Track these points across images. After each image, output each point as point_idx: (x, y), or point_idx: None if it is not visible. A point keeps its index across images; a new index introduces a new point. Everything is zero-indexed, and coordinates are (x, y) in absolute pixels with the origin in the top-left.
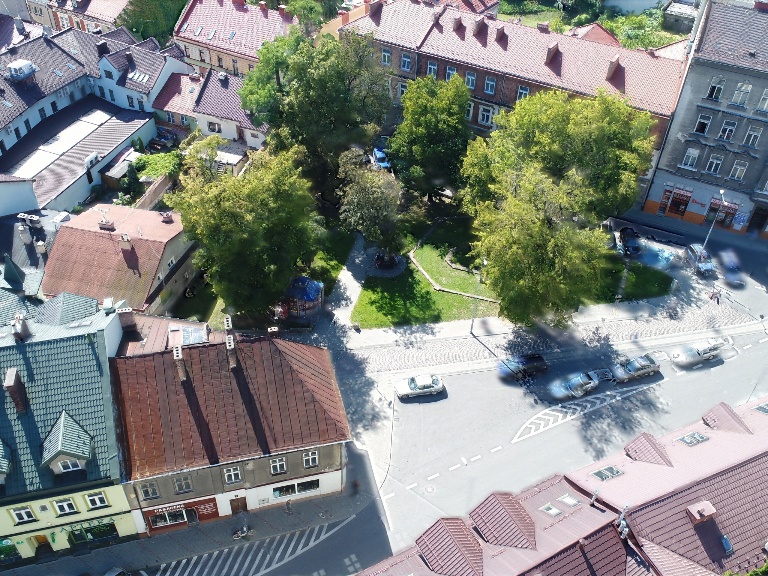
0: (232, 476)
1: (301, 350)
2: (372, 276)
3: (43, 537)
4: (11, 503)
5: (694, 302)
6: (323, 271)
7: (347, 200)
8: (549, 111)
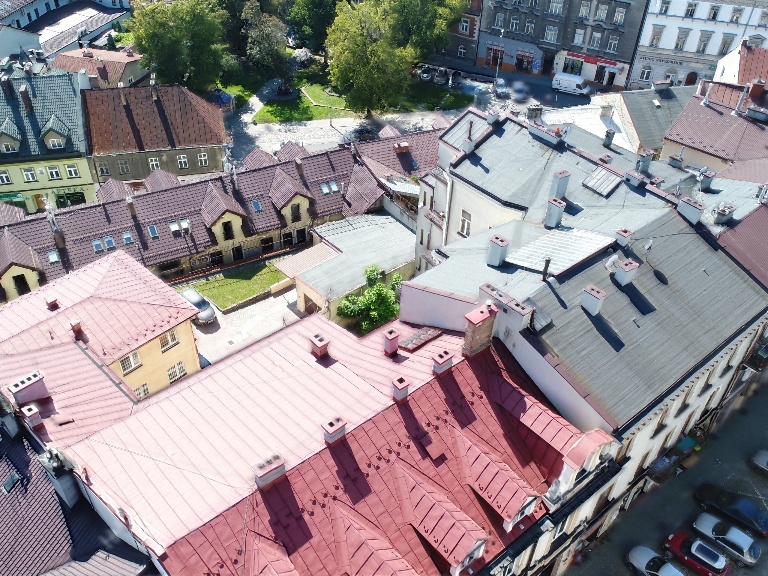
0: (154, 166)
1: (201, 100)
2: (272, 99)
3: (42, 204)
4: (23, 162)
5: (488, 110)
6: (239, 97)
7: (251, 40)
8: None
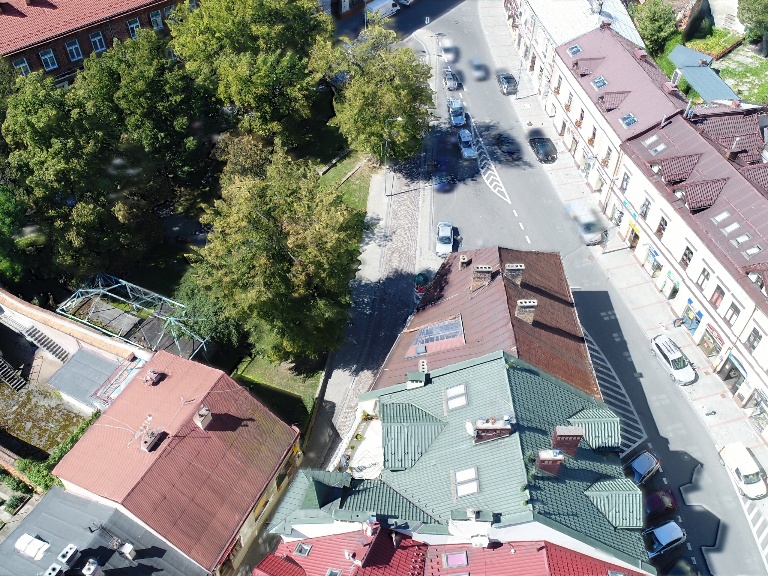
0: None
1: None
2: None
3: None
4: None
5: None
6: None
7: None
8: (251, 2)
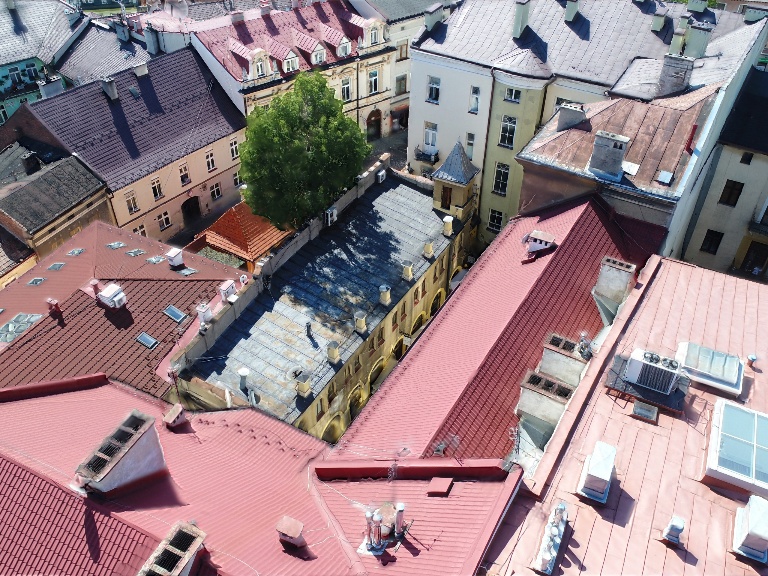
0: None
1: None
2: None
3: None
4: (96, 9)
5: None
6: None
7: None
8: None
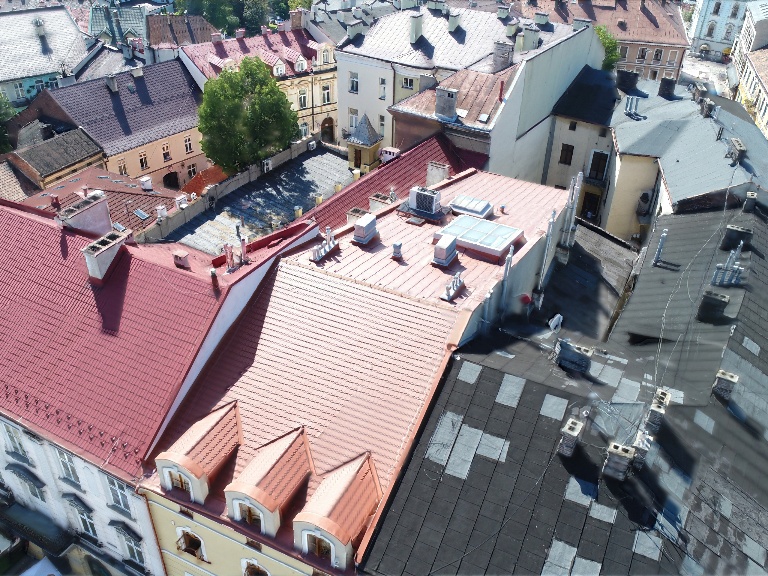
0: None
1: (212, 26)
2: None
3: None
4: None
5: None
6: None
7: (246, 7)
8: None
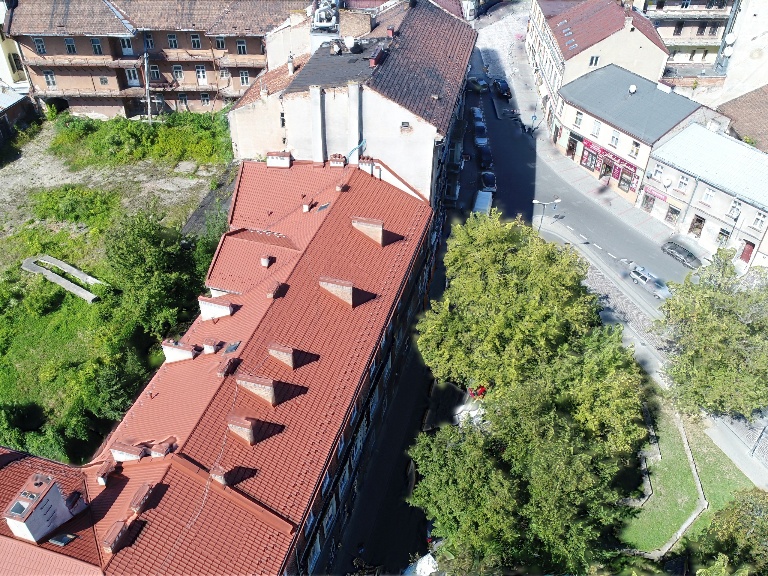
0: None
1: None
2: None
3: None
4: None
5: None
6: None
7: None
8: (570, 282)
